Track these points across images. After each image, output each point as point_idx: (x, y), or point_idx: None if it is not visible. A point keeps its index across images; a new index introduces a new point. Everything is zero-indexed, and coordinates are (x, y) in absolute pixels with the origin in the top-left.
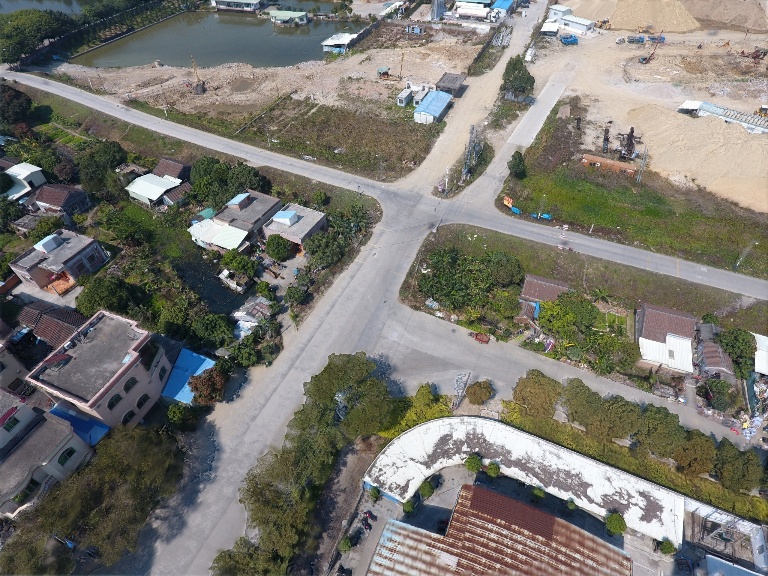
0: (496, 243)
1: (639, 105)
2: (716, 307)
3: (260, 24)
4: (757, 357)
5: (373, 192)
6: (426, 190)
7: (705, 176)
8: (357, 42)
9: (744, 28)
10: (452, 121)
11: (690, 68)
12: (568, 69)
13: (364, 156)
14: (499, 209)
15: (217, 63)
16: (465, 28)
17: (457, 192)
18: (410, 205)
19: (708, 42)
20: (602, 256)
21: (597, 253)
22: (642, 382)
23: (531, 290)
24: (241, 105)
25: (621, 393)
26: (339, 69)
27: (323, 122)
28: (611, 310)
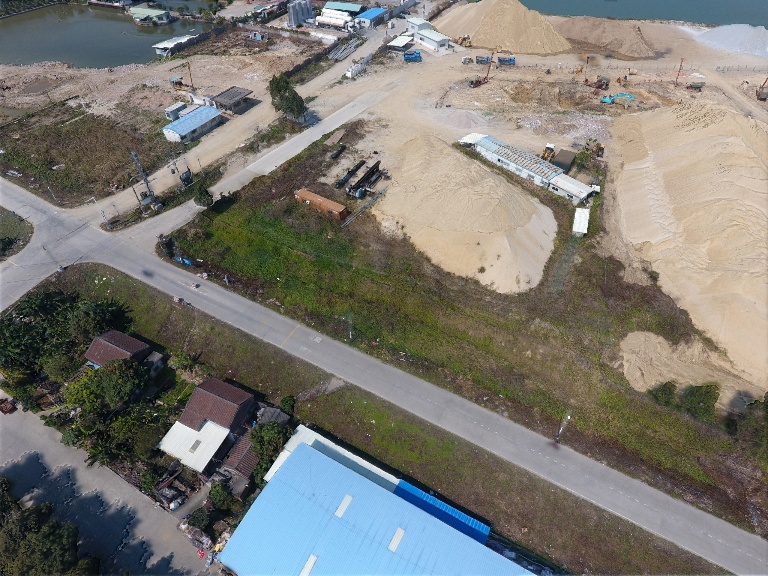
0: (121, 289)
1: (427, 134)
2: (302, 388)
3: (131, 21)
4: (278, 460)
5: (38, 218)
6: (99, 220)
7: (413, 224)
8: (188, 46)
9: (616, 53)
10: (208, 140)
11: (522, 95)
12: (386, 89)
13: (74, 175)
14: (156, 248)
15: (35, 61)
16: (311, 37)
17: (129, 225)
18: (63, 237)
19: (563, 67)
20: (217, 314)
21: (215, 310)
22: (153, 477)
23: (95, 352)
24: (17, 108)
25: (109, 491)
26: (141, 75)
27: (68, 133)
28: (194, 380)
